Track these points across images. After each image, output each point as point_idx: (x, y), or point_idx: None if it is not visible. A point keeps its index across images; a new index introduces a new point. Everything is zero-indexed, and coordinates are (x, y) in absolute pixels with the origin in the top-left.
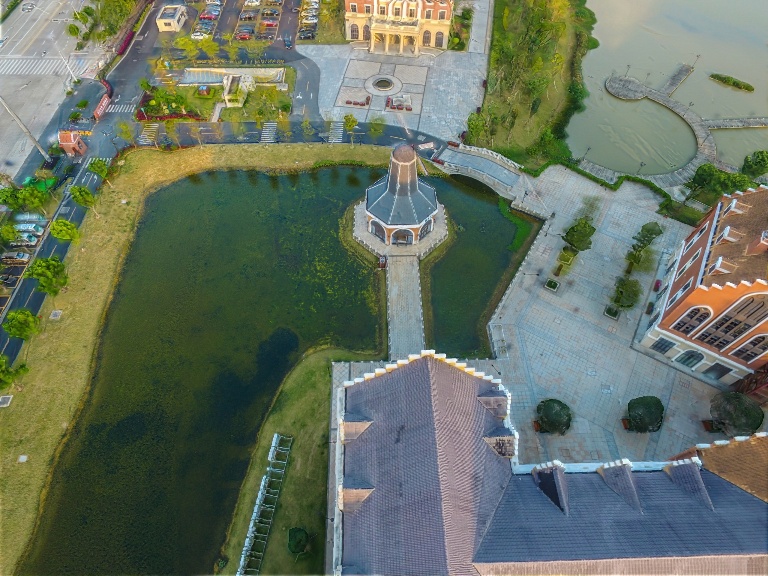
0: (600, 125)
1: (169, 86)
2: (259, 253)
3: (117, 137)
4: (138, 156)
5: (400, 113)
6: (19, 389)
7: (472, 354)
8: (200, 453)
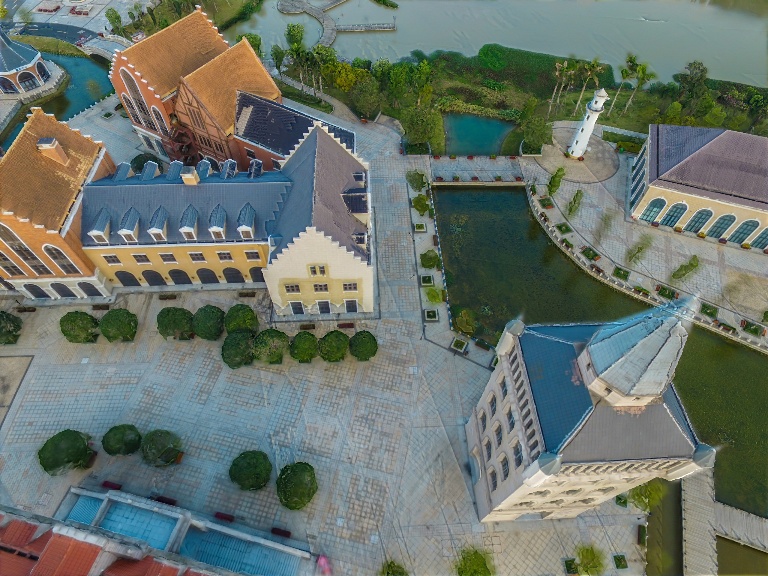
0: (252, 30)
1: None
2: None
3: None
4: None
5: (77, 17)
6: None
7: None
8: None
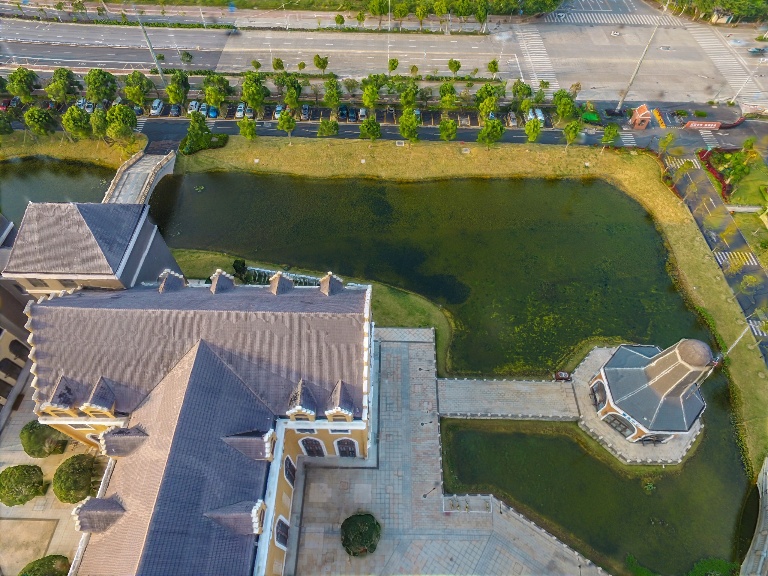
0: None
1: (766, 165)
2: (554, 267)
3: (658, 139)
4: (646, 161)
5: None
6: (408, 147)
7: (451, 471)
8: (361, 247)
